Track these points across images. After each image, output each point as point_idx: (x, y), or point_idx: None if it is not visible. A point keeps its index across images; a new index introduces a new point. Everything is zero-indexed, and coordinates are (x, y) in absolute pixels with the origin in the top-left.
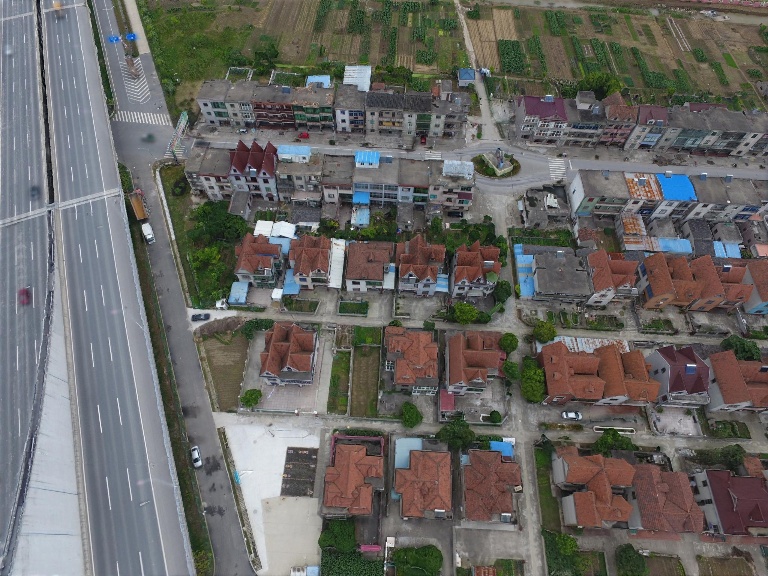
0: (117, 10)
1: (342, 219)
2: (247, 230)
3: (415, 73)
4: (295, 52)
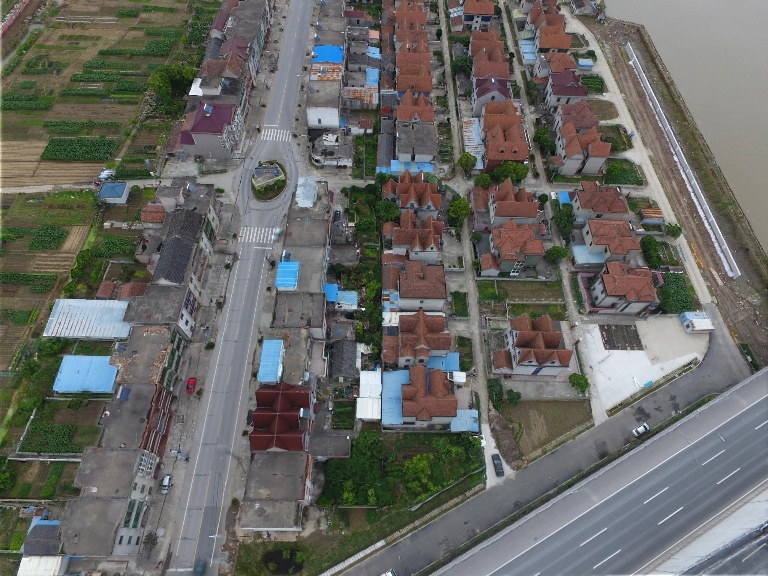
0: None
1: None
2: None
3: None
4: None
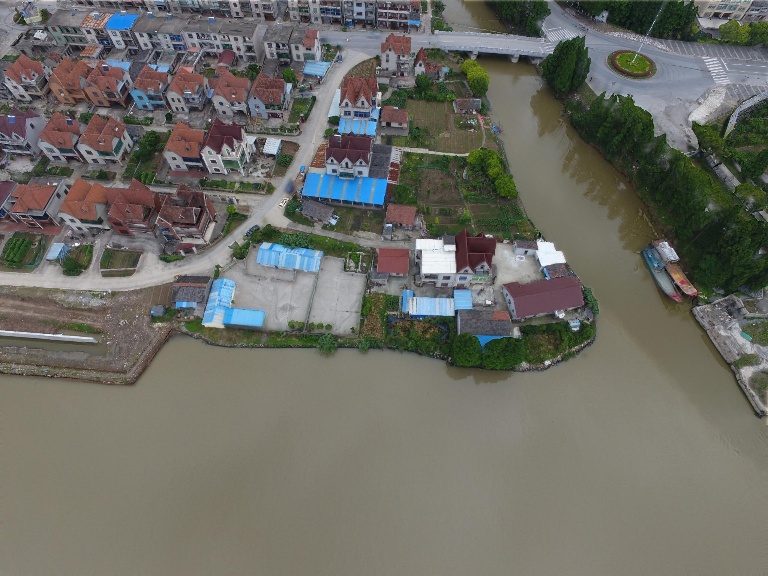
0: None
1: None
2: None
3: None
4: None
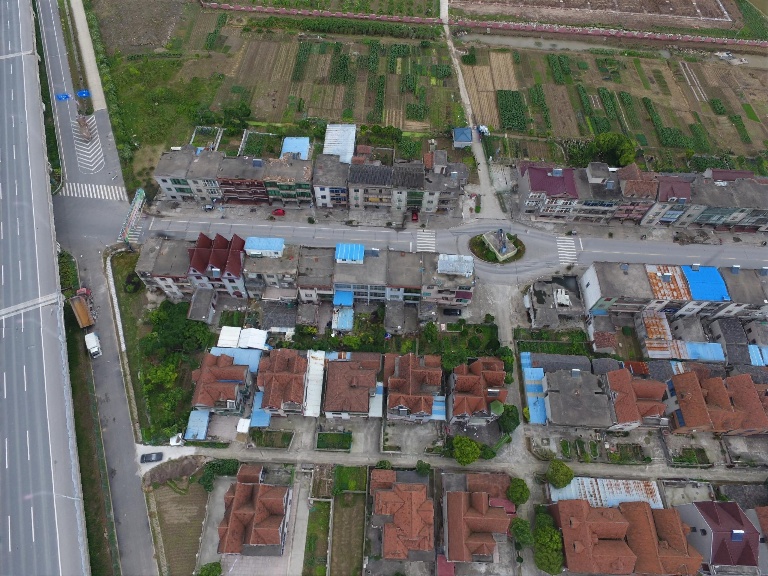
0: (71, 56)
1: (322, 320)
2: (210, 337)
3: (405, 131)
4: (271, 106)
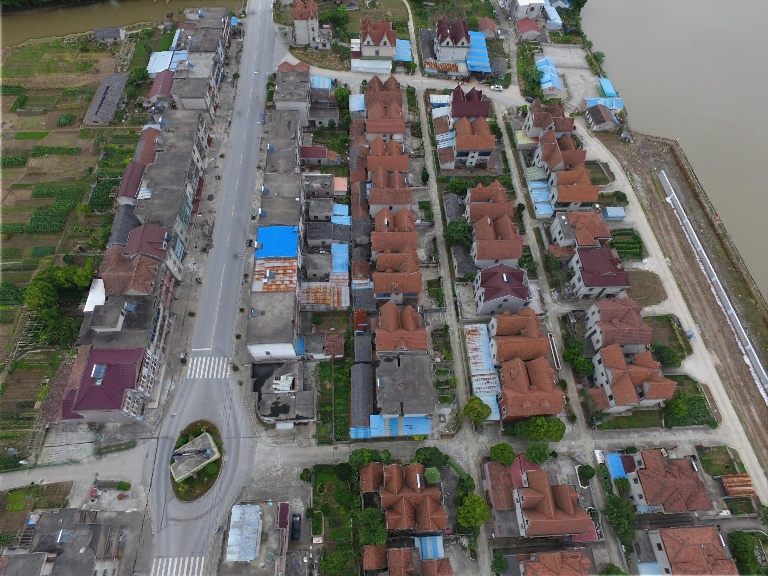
0: None
1: None
2: None
3: None
4: None
